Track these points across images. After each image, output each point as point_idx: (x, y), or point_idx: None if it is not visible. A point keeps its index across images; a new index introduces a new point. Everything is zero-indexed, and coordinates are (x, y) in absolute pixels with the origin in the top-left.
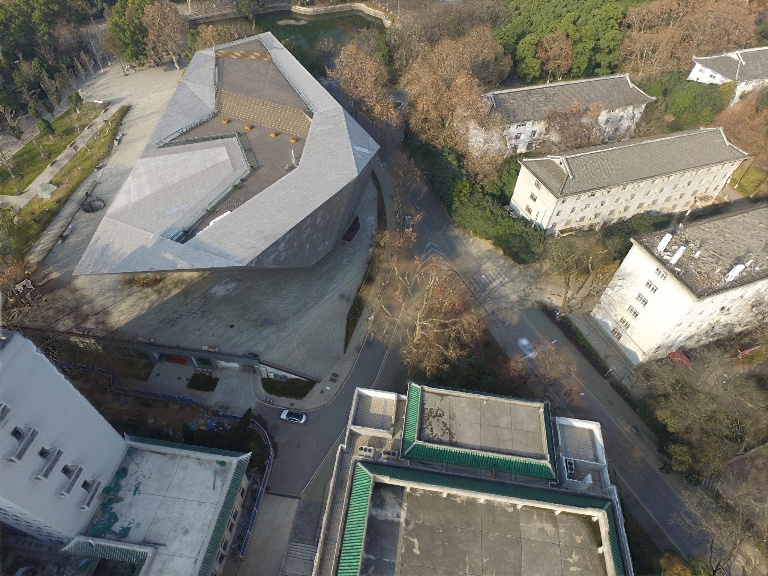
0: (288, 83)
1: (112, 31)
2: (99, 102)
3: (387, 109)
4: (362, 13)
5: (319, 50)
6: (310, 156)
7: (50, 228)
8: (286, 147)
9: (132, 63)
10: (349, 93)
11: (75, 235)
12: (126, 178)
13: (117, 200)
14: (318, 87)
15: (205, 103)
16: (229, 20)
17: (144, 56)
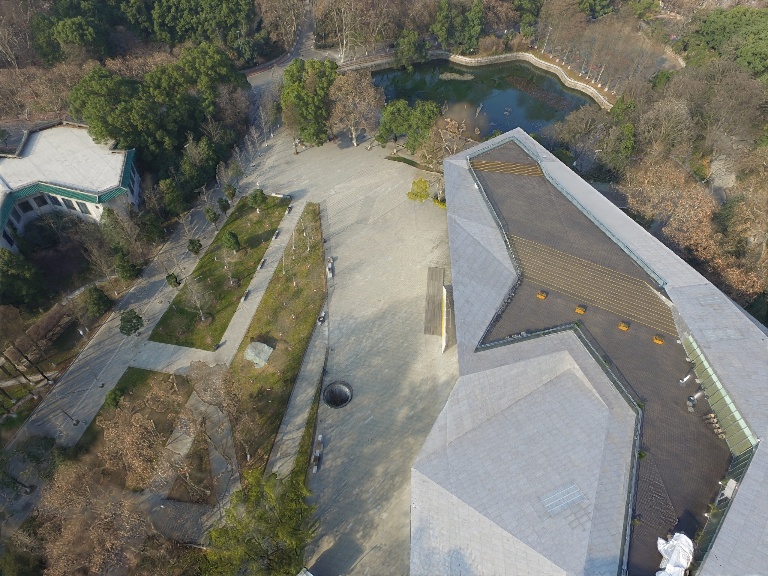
0: (591, 223)
1: (294, 105)
2: (278, 196)
3: (727, 265)
4: (528, 64)
5: (504, 119)
6: (764, 415)
7: (284, 429)
8: (655, 355)
9: (312, 143)
10: (673, 239)
11: (330, 454)
12: (363, 340)
13: (429, 441)
14: (649, 238)
15: (495, 257)
16: (382, 71)
17: (326, 135)
